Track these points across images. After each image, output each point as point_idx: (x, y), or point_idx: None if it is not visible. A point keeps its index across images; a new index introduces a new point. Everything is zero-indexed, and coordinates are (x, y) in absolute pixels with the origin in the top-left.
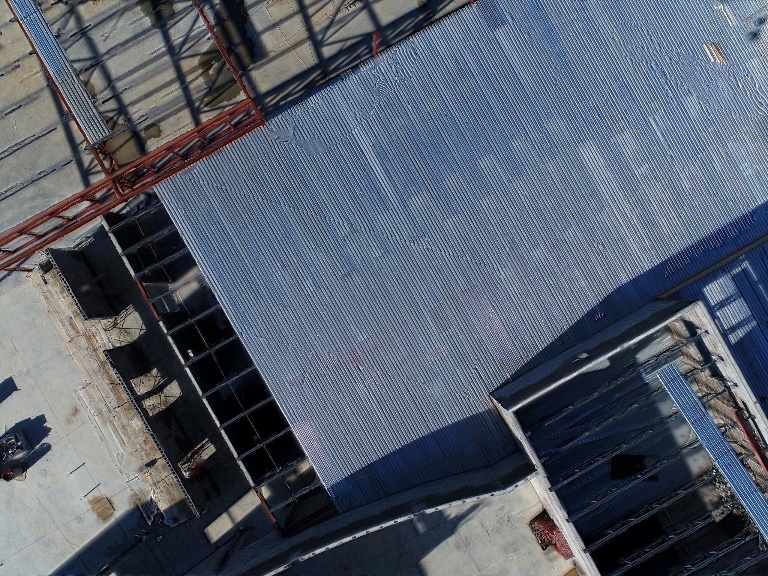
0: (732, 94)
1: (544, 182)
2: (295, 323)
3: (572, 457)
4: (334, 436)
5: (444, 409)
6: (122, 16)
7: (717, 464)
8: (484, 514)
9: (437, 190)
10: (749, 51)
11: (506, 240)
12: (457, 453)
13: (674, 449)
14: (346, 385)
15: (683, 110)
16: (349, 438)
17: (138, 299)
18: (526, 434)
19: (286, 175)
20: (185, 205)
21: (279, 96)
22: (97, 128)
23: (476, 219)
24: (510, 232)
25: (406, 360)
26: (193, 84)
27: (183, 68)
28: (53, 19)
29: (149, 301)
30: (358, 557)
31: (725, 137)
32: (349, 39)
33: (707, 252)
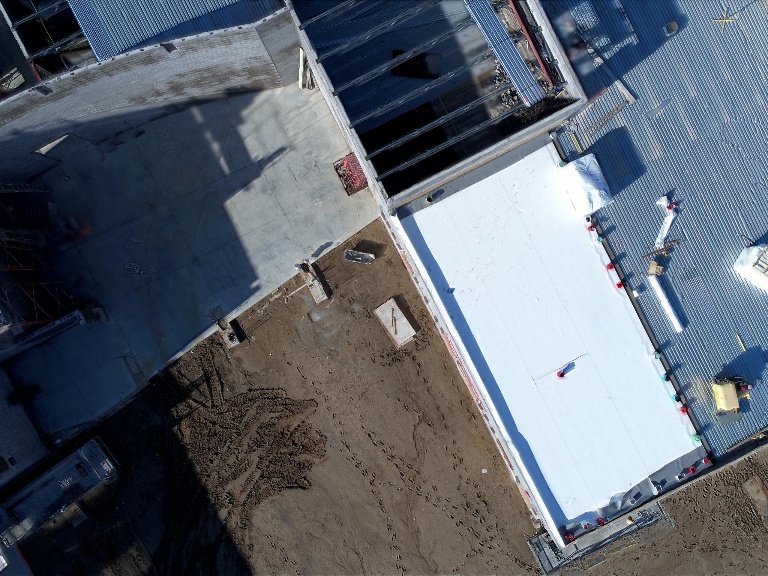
0: None
1: None
2: None
3: (353, 51)
4: (109, 9)
5: None
6: None
7: (469, 8)
8: (291, 158)
9: None
10: None
11: None
12: None
13: (457, 48)
14: None
15: None
16: (124, 12)
17: None
18: None
19: None
20: None
21: None
22: None
23: None
24: None
25: None
26: None
27: None
28: None
29: None
30: (164, 195)
31: None
32: None
33: None
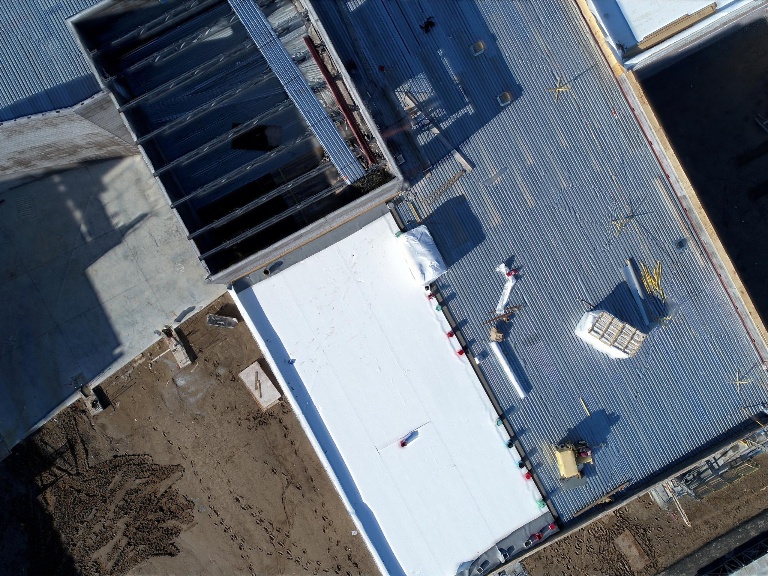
0: None
1: None
2: None
3: (192, 124)
4: None
5: (58, 67)
6: None
7: (286, 89)
8: (152, 224)
9: None
10: None
11: None
12: None
13: (296, 120)
14: None
15: None
16: None
17: None
18: (92, 51)
19: None
20: None
21: None
22: None
23: None
24: None
25: (20, 16)
26: None
27: None
28: None
29: None
30: (24, 263)
31: None
32: None
33: None
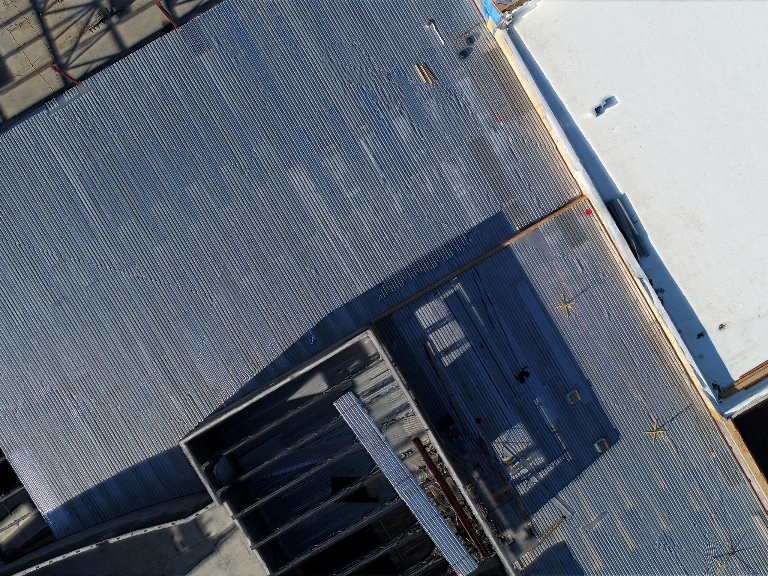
0: (453, 113)
1: (255, 208)
2: (6, 353)
3: None
4: (49, 464)
5: (159, 435)
6: None
7: (396, 490)
8: None
9: (146, 218)
10: (462, 70)
11: (217, 267)
12: (173, 478)
13: None
14: (60, 414)
15: (395, 132)
16: (64, 466)
17: None
18: (204, 464)
19: None
20: None
21: None
22: None
23: (186, 246)
24: (221, 258)
25: (119, 388)
26: None
27: None
28: None
29: None
30: (120, 575)
31: (438, 158)
32: (94, 61)
33: (422, 274)
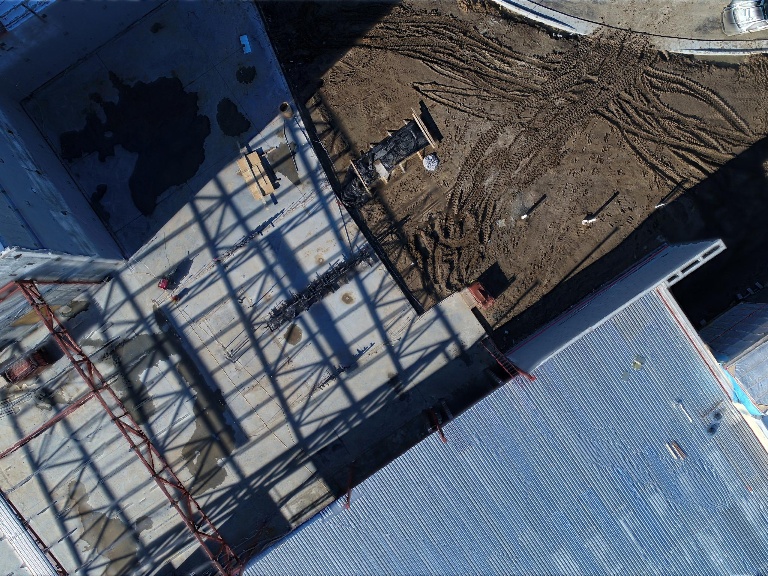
0: (699, 477)
1: None
2: None
3: None
4: None
5: None
6: (105, 416)
7: None
8: None
9: None
10: (711, 445)
11: None
12: None
13: None
14: None
15: (652, 510)
16: None
17: None
18: None
19: None
20: None
21: (263, 478)
22: None
23: None
24: None
25: None
26: (179, 474)
27: (168, 460)
28: (39, 425)
29: None
30: None
31: (695, 531)
32: (325, 417)
33: None
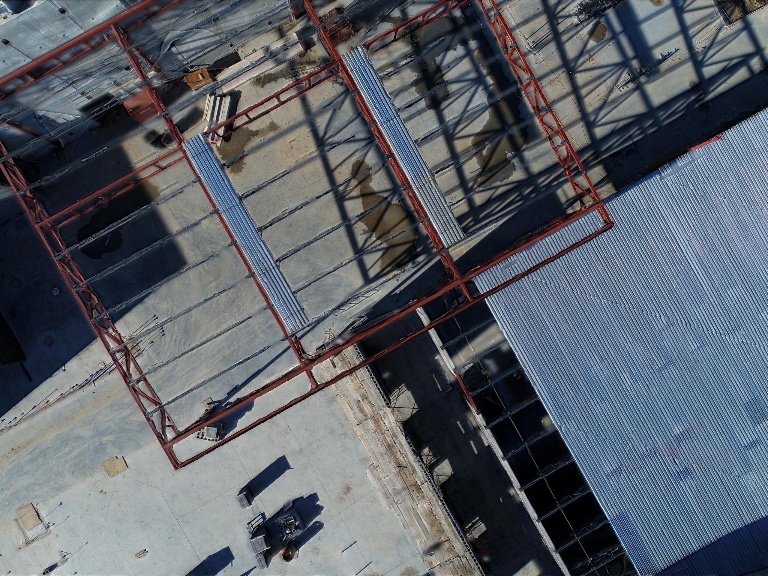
0: None
1: None
2: (613, 416)
3: None
4: (651, 529)
5: (758, 502)
6: (397, 97)
7: None
8: None
9: (752, 284)
10: None
11: None
12: None
13: None
14: (662, 478)
15: None
16: (666, 531)
17: (411, 378)
18: None
19: (604, 269)
20: (505, 299)
21: (552, 177)
22: (453, 232)
23: None
24: None
25: (721, 453)
26: (467, 164)
27: (457, 149)
28: (329, 99)
29: (470, 395)
30: None
31: None
32: (621, 120)
33: None
